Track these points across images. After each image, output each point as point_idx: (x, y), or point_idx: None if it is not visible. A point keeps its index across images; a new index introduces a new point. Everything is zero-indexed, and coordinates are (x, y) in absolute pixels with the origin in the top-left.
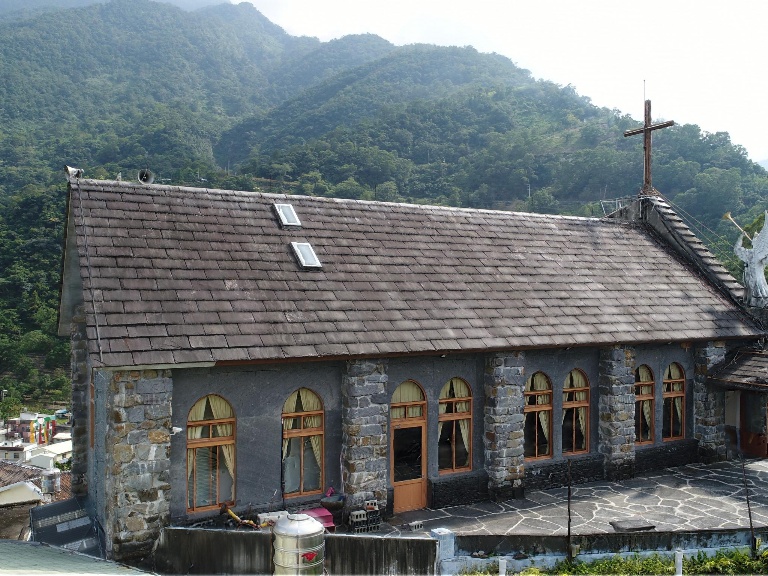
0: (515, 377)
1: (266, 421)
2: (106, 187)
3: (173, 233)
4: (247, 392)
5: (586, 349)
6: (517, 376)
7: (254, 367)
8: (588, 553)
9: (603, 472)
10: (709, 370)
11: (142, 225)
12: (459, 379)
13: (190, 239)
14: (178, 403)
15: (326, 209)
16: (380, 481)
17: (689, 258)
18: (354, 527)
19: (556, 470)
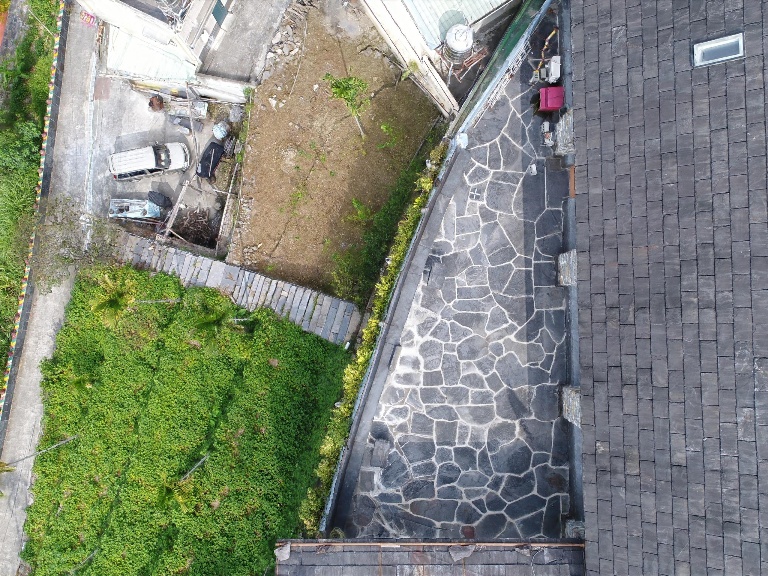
0: None
1: None
2: None
3: None
4: None
5: None
6: None
7: None
8: None
9: None
10: None
11: None
12: None
13: None
14: None
15: None
16: None
17: None
18: None
19: None
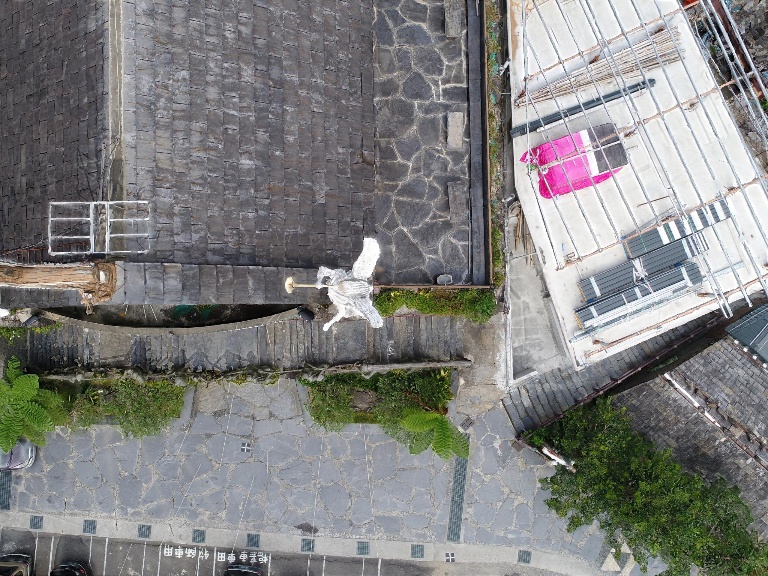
0: None
1: None
2: None
3: None
4: None
5: None
6: None
7: None
8: None
9: None
10: None
11: None
12: None
13: None
14: None
15: None
16: None
17: None
18: None
19: None
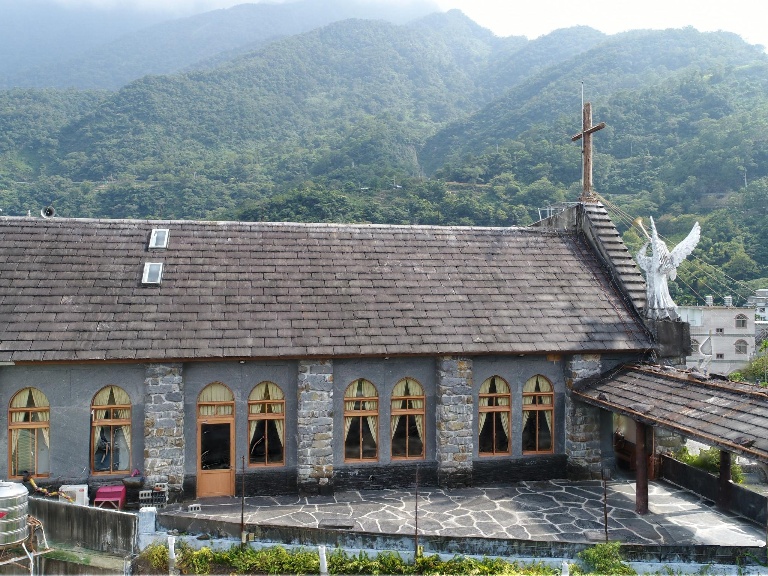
0: (321, 383)
1: (76, 411)
2: (13, 222)
3: (45, 258)
4: (59, 387)
5: (420, 359)
6: (323, 382)
7: (66, 367)
8: (263, 541)
9: (437, 479)
10: (575, 384)
11: (23, 252)
12: (272, 383)
13: (57, 262)
14: (0, 393)
15: (204, 232)
16: (174, 467)
17: (606, 267)
18: (139, 503)
19: (378, 473)
